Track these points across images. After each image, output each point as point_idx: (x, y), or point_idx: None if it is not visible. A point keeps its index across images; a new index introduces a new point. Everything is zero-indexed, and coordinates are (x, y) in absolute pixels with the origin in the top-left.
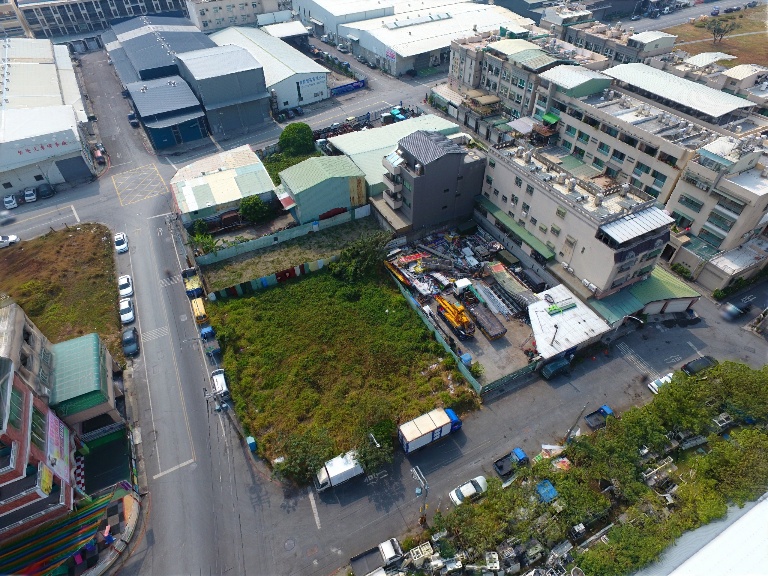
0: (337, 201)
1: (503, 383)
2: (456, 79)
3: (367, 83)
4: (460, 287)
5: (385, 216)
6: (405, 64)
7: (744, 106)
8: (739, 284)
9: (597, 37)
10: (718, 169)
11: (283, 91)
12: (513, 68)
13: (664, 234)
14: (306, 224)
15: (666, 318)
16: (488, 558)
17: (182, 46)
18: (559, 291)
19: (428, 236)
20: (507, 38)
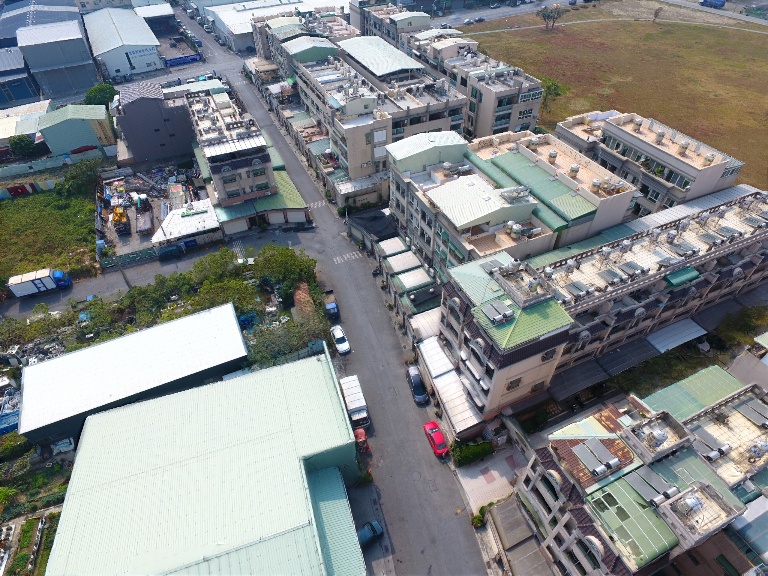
0: (85, 140)
1: (126, 262)
2: (258, 52)
3: (203, 57)
4: (135, 199)
5: (118, 151)
6: (244, 41)
7: (409, 68)
8: (363, 205)
9: (376, 17)
10: (342, 112)
11: (113, 60)
12: (275, 40)
13: (261, 155)
14: (57, 157)
15: (288, 226)
16: (11, 348)
17: (46, 22)
18: (203, 202)
19: (155, 169)
20: (296, 16)
